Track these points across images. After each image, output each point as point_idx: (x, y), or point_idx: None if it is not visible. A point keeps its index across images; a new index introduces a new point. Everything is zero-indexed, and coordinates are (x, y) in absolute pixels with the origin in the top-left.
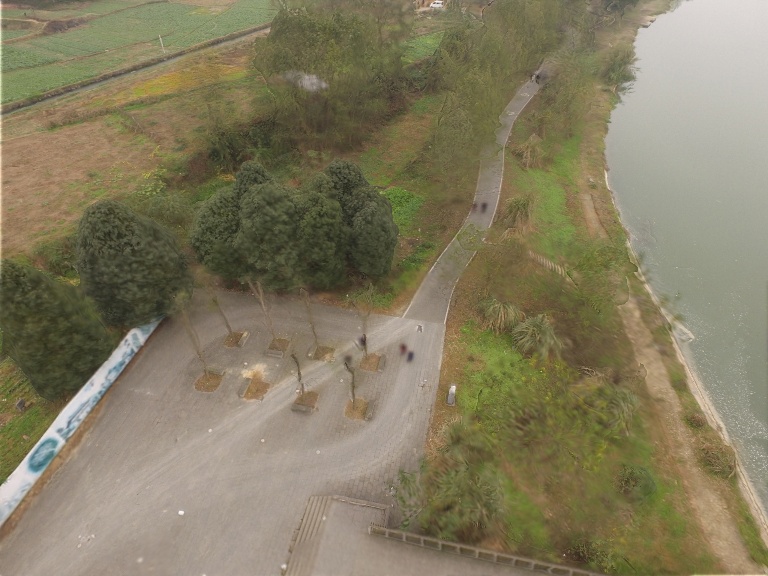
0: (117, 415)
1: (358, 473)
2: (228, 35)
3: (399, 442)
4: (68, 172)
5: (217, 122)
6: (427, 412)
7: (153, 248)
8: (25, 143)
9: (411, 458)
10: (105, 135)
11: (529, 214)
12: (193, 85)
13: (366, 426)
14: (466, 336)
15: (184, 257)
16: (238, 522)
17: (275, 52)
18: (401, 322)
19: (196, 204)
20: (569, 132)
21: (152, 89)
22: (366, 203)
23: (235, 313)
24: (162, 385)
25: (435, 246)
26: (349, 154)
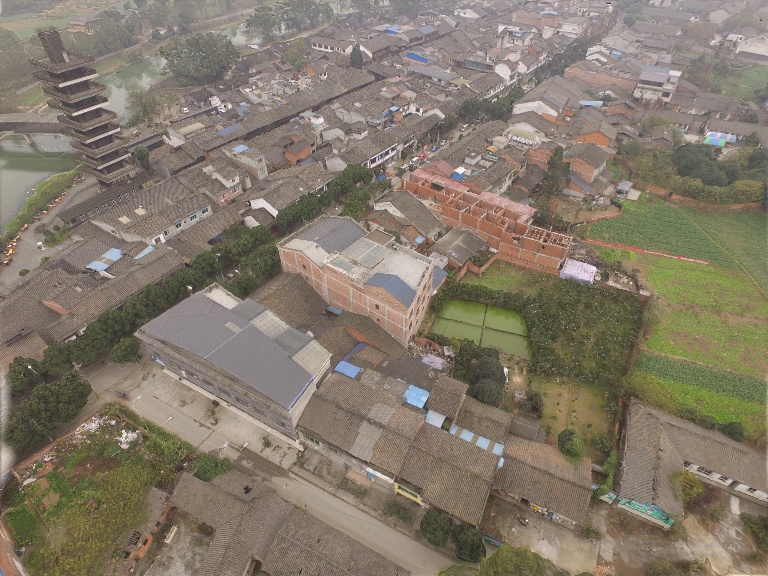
0: None
1: None
2: None
3: None
4: None
5: None
6: None
7: None
8: None
9: None
10: None
11: (12, 94)
12: None
13: None
14: None
15: None
16: None
17: None
18: None
19: None
20: None
21: None
22: None
23: None
24: None
25: None
26: None
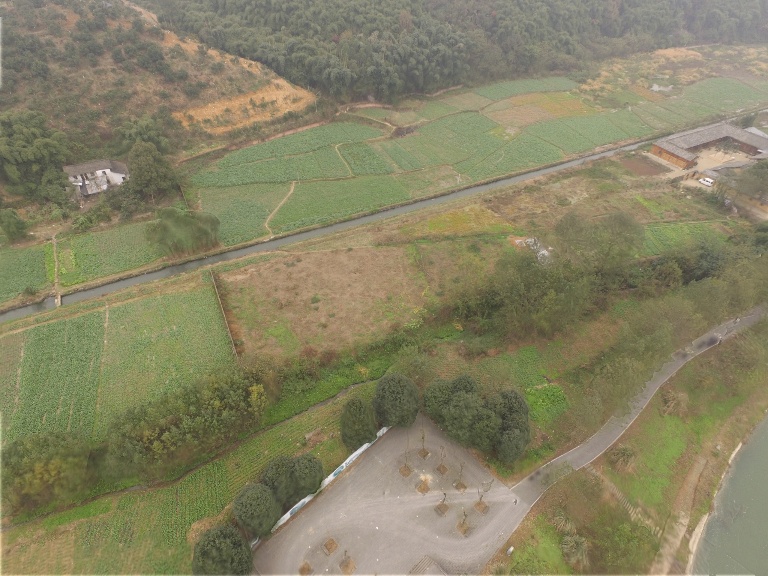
0: (366, 466)
1: (450, 558)
2: (507, 175)
3: (474, 556)
4: (378, 290)
5: (466, 292)
6: (494, 550)
7: (408, 403)
8: (363, 254)
9: (475, 568)
10: (403, 264)
11: (629, 463)
12: (465, 230)
13: (463, 539)
14: (538, 522)
15: (418, 402)
16: (396, 546)
17: (515, 282)
18: (508, 492)
19: (434, 341)
20: (734, 391)
21: (440, 225)
22: (514, 429)
23: (429, 437)
24: (386, 461)
25: (555, 450)
26: (541, 339)
